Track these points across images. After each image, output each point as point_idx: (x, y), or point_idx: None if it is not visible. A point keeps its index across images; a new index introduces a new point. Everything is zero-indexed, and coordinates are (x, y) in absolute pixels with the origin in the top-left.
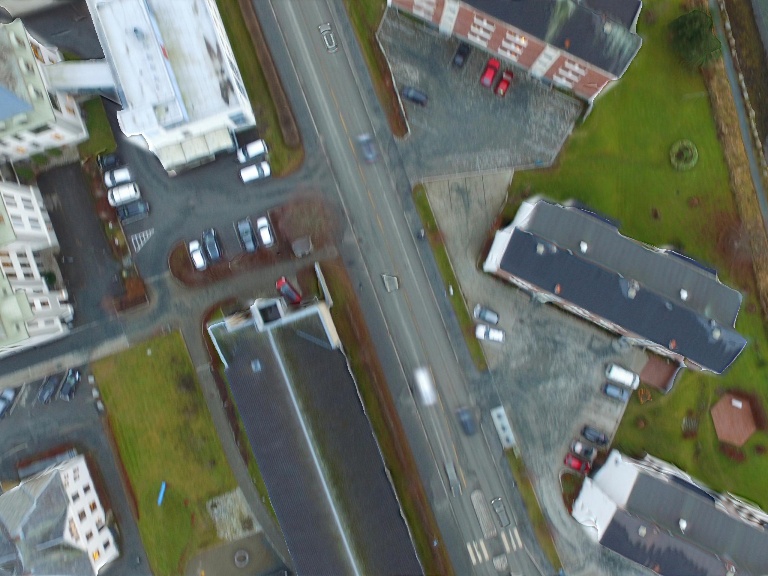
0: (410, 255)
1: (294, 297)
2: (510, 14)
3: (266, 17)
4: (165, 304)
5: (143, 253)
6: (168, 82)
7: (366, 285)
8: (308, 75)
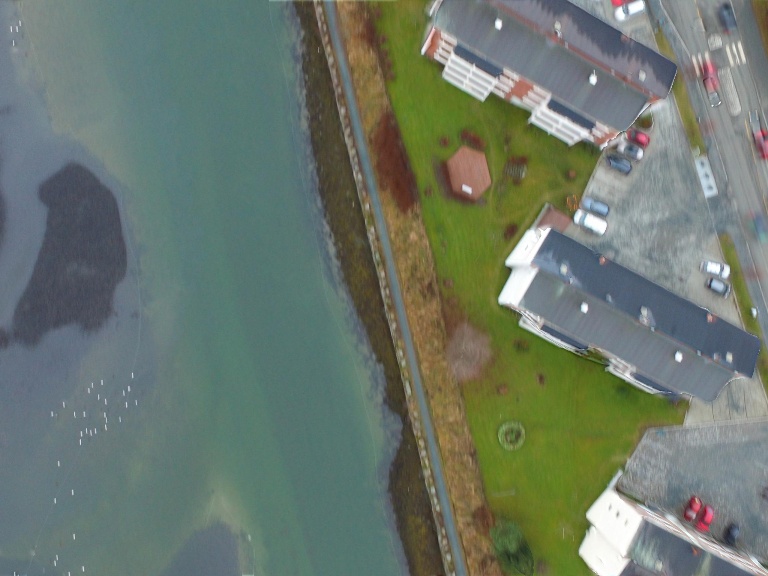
0: None
1: None
2: None
3: None
4: None
5: None
6: None
7: None
8: None
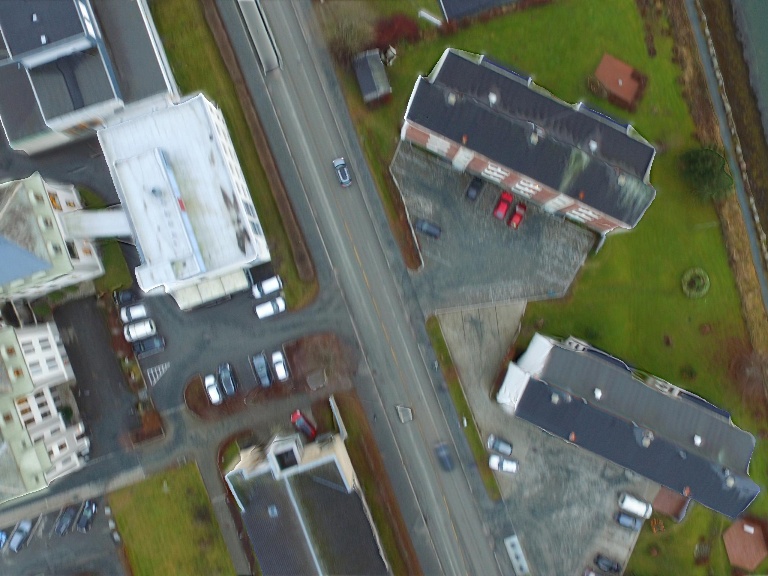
0: (424, 386)
1: (309, 432)
2: (524, 165)
3: (280, 152)
4: (181, 436)
5: (159, 386)
6: (186, 238)
7: (380, 416)
8: (322, 209)
